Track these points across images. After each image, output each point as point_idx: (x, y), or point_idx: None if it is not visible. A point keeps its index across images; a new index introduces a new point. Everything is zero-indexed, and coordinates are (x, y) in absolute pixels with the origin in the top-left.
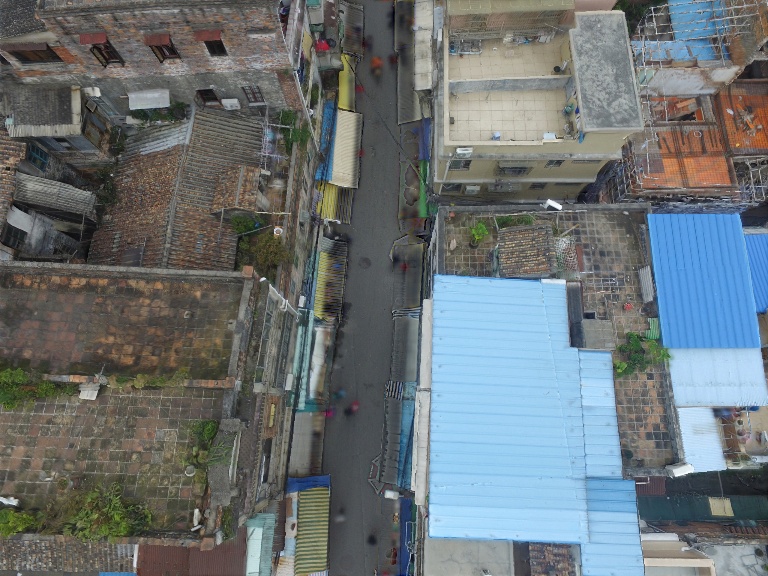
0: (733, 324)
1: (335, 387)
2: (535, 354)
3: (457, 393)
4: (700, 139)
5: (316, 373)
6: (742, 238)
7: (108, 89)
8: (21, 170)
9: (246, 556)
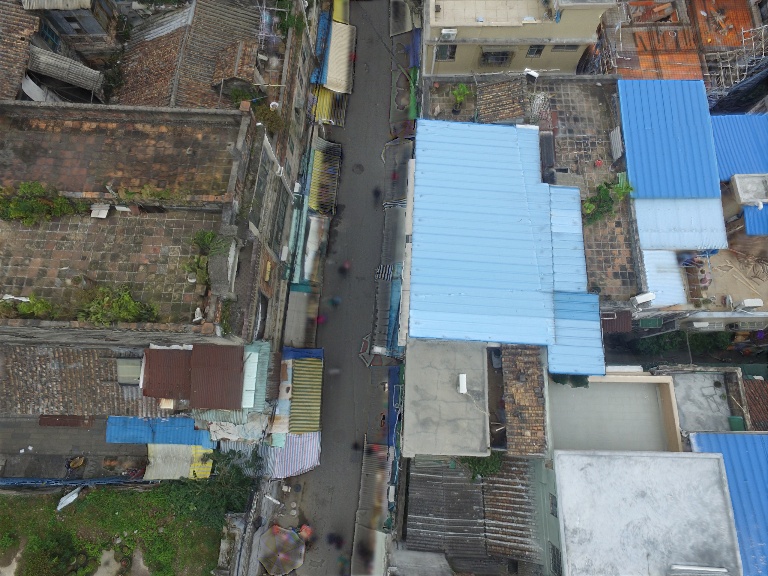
0: (696, 176)
1: (329, 280)
2: (509, 188)
3: (437, 218)
4: (675, 38)
5: (310, 258)
6: (706, 101)
7: None
8: (34, 44)
9: (243, 374)
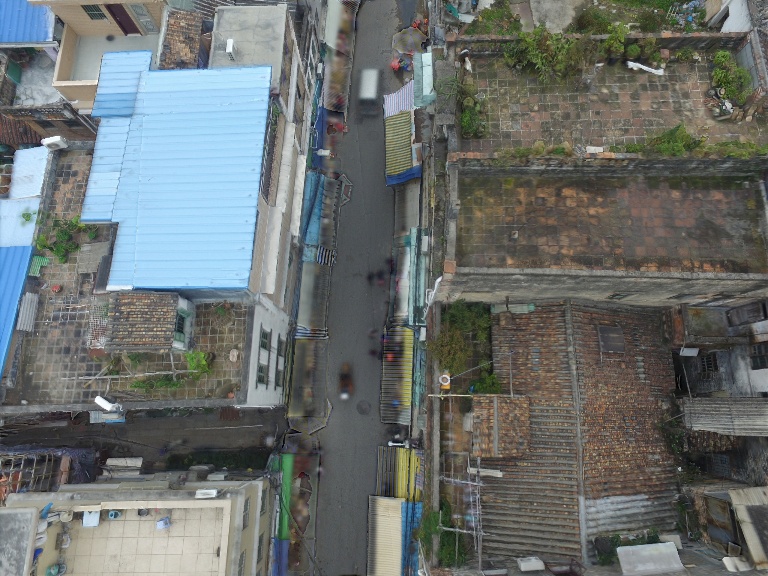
0: None
1: None
2: (155, 213)
3: (236, 173)
4: None
5: (406, 271)
6: None
7: (716, 572)
8: None
9: None
